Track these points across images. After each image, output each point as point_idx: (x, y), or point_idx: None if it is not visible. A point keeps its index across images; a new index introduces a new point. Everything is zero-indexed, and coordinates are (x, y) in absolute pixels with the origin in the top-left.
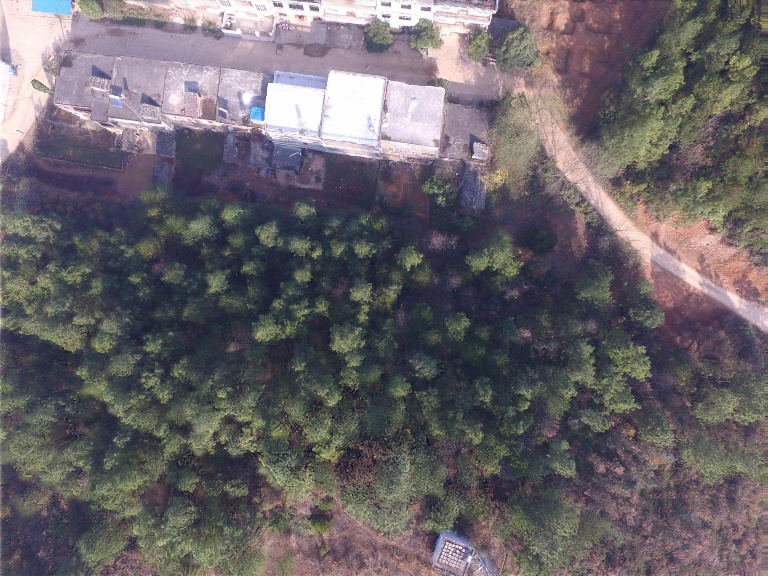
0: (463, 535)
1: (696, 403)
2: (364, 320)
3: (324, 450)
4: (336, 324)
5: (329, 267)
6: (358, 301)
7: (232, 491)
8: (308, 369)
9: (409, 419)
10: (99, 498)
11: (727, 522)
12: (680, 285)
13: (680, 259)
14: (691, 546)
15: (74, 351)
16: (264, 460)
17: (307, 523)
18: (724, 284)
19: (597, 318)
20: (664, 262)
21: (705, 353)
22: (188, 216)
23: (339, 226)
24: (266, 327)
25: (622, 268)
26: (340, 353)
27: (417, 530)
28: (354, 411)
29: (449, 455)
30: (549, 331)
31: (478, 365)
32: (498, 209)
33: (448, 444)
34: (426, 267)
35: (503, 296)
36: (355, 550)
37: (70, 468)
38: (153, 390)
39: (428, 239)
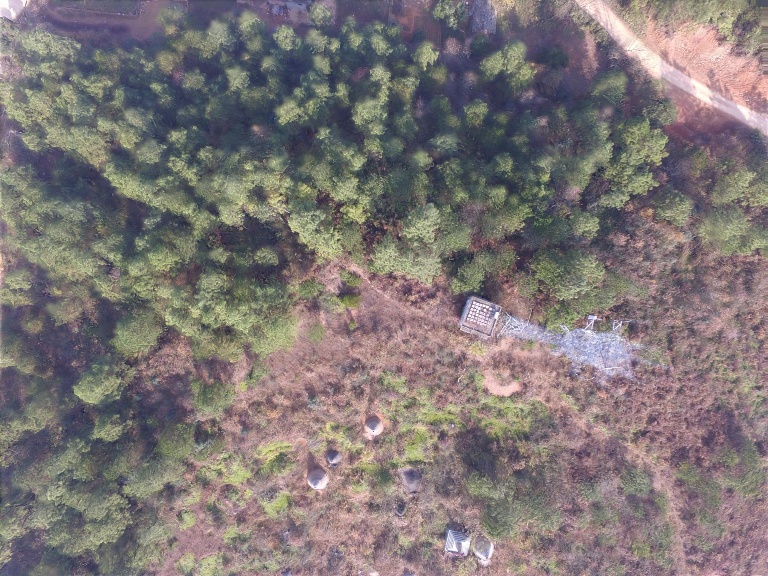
0: (489, 295)
1: (711, 192)
2: (385, 101)
3: (352, 210)
4: (358, 102)
5: (348, 58)
6: (378, 80)
7: (263, 257)
8: (333, 135)
9: (432, 190)
10: (132, 284)
11: (745, 308)
12: (691, 101)
13: (690, 75)
14: (711, 317)
15: (99, 163)
16: (293, 225)
17: (336, 300)
18: (734, 97)
19: (612, 109)
20: (674, 79)
21: (718, 155)
22: (206, 31)
23: (355, 27)
24: (289, 111)
25: (633, 83)
26: (363, 124)
27: (444, 300)
28: (379, 178)
29: (473, 217)
30: (565, 123)
31: (497, 146)
32: (509, 36)
33: (472, 206)
34: (442, 66)
35: (518, 100)
36: (384, 323)
37: (101, 262)
38: (181, 174)
39: (442, 47)
